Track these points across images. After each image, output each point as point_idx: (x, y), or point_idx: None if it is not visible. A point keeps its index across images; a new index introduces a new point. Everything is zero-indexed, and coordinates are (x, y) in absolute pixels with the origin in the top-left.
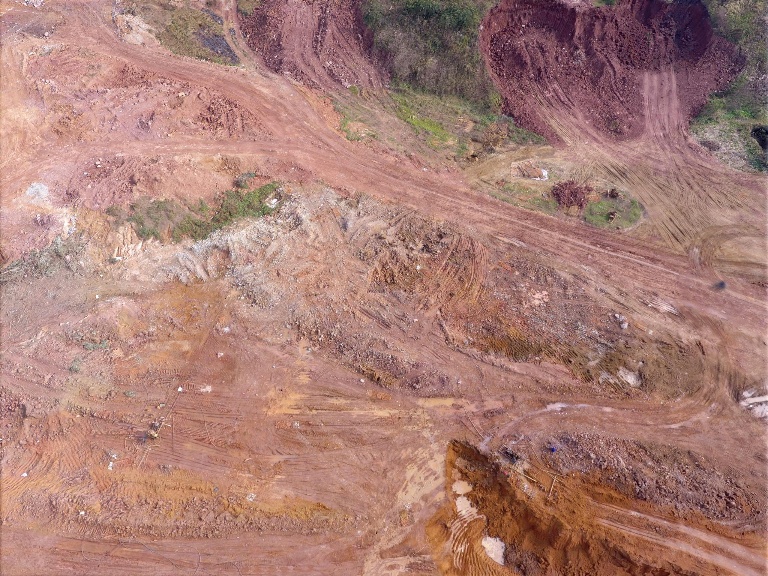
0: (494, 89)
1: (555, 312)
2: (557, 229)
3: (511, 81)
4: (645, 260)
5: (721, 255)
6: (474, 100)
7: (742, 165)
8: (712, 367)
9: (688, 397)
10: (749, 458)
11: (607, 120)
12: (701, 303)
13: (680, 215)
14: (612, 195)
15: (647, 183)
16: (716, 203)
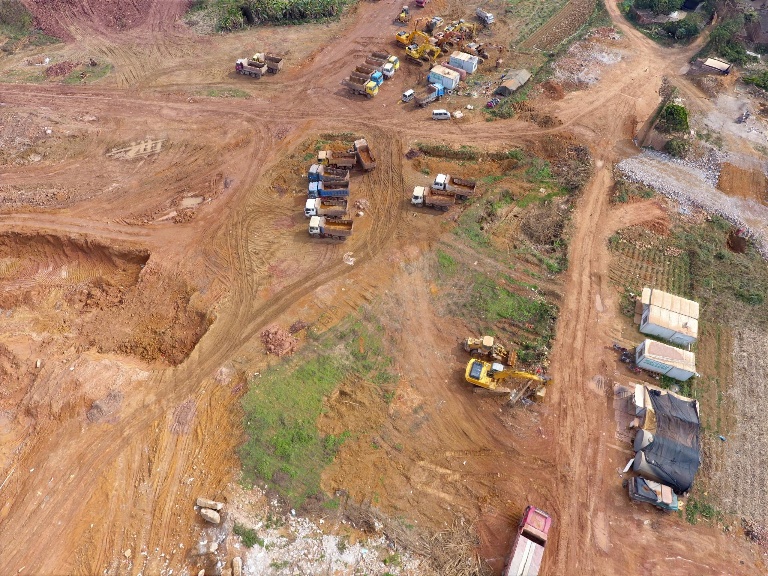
0: (27, 12)
1: (1, 135)
2: (34, 90)
3: (45, 5)
4: (92, 96)
5: (153, 84)
6: (14, 24)
7: (208, 31)
8: (100, 141)
9: (70, 158)
10: (92, 178)
11: (120, 20)
12: (118, 111)
13: (139, 67)
14: (93, 64)
15: (127, 53)
16: (172, 56)
